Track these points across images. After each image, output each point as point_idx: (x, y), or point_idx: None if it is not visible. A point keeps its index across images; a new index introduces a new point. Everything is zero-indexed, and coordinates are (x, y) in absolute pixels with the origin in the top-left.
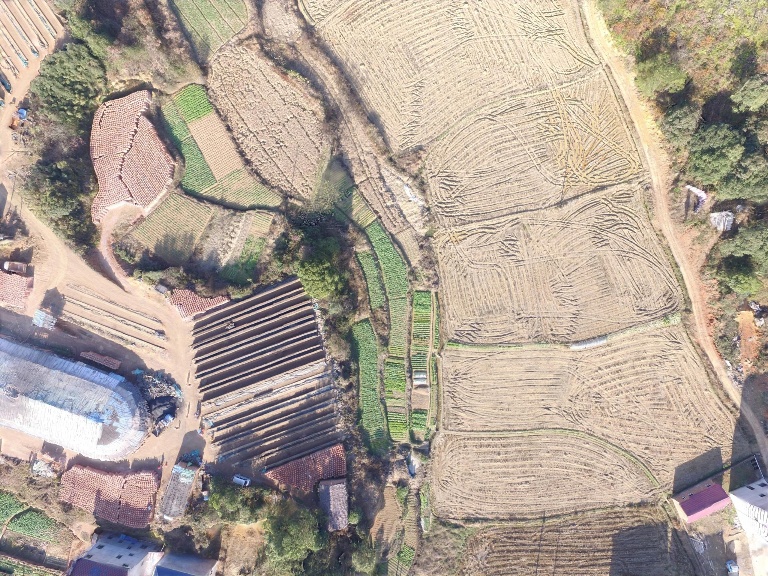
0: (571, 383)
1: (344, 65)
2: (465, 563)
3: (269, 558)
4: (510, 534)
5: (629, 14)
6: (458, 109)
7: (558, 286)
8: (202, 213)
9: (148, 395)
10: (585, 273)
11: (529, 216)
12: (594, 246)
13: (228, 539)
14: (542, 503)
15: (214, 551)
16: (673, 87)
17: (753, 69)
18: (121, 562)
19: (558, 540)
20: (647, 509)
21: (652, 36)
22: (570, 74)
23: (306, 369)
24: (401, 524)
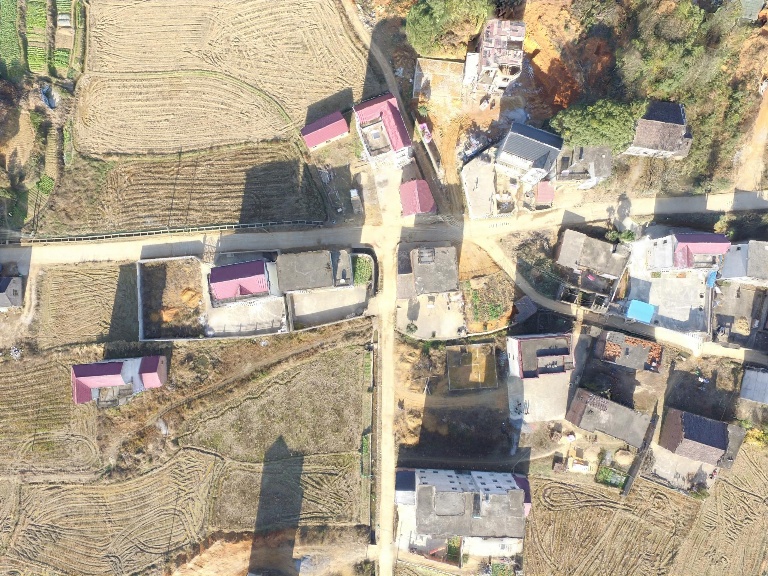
0: (212, 28)
1: None
2: (105, 196)
3: None
4: (148, 168)
5: None
6: None
7: None
8: None
9: None
10: None
11: None
12: None
13: None
14: (180, 139)
15: None
16: None
17: None
18: None
19: (194, 175)
20: (280, 145)
21: None
22: None
23: None
24: (36, 149)
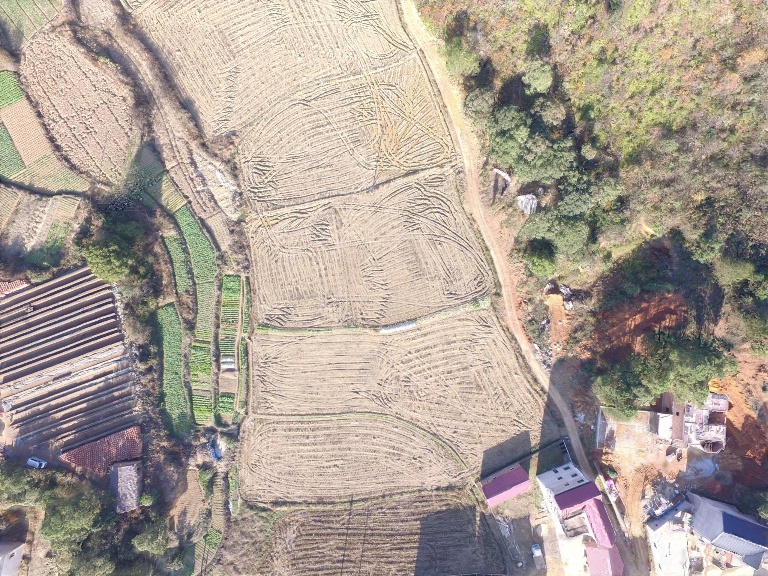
0: (380, 367)
1: (160, 51)
2: (273, 546)
3: None
4: (318, 517)
5: None
6: (272, 94)
7: (369, 270)
8: (9, 198)
9: None
10: (396, 257)
11: (341, 200)
12: (405, 230)
13: (35, 522)
14: (350, 487)
15: (20, 534)
16: (474, 70)
17: (547, 51)
18: None
19: (366, 524)
20: (455, 493)
21: (454, 19)
22: (384, 59)
23: (105, 352)
24: (204, 507)
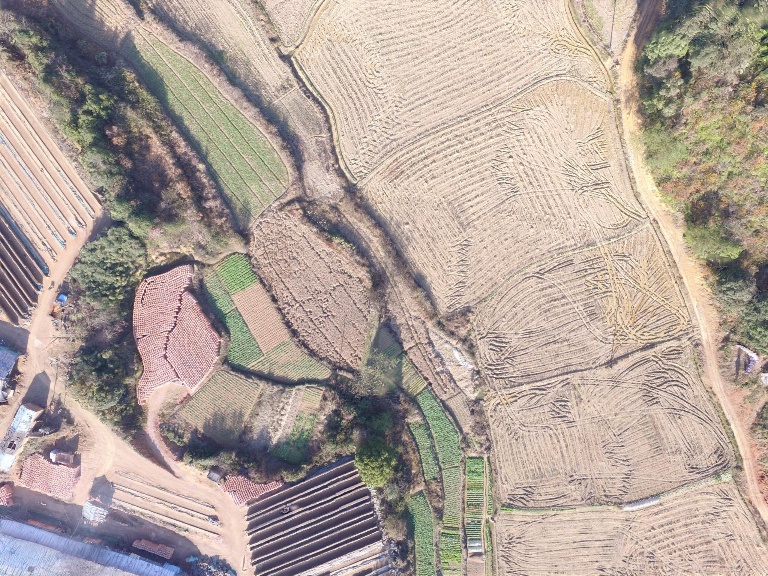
0: (625, 543)
1: (388, 224)
2: None
3: None
4: None
5: (679, 174)
6: (505, 268)
7: (610, 446)
8: (250, 390)
9: None
10: (636, 432)
11: (579, 376)
12: (645, 405)
13: None
14: None
15: None
16: (725, 252)
17: None
18: None
19: None
20: None
21: (703, 199)
22: (617, 229)
23: (363, 550)
24: None
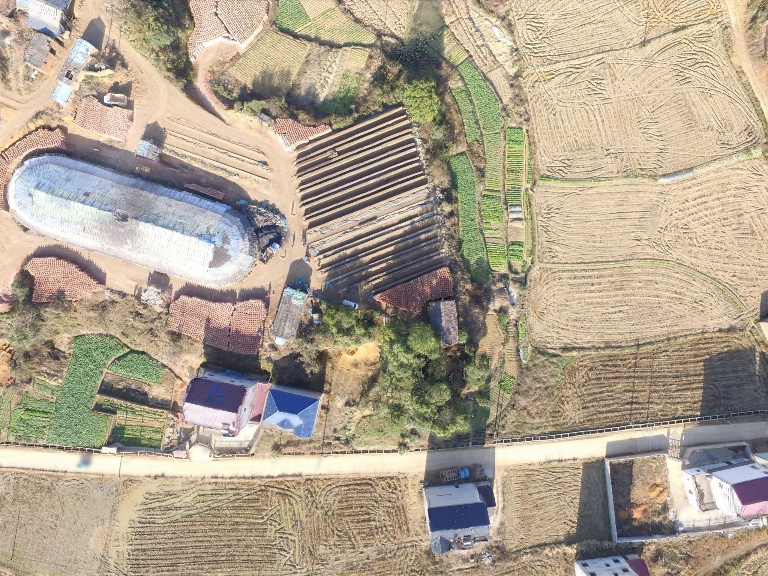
0: (660, 215)
1: None
2: (563, 391)
3: (382, 376)
4: (606, 362)
5: None
6: None
7: (644, 122)
8: (298, 50)
9: (254, 224)
10: (670, 109)
11: (614, 56)
12: (677, 83)
13: (332, 373)
14: (636, 331)
15: (319, 384)
16: None
17: None
18: (236, 383)
19: (652, 366)
20: (736, 334)
21: None
22: None
23: (409, 196)
24: (503, 351)
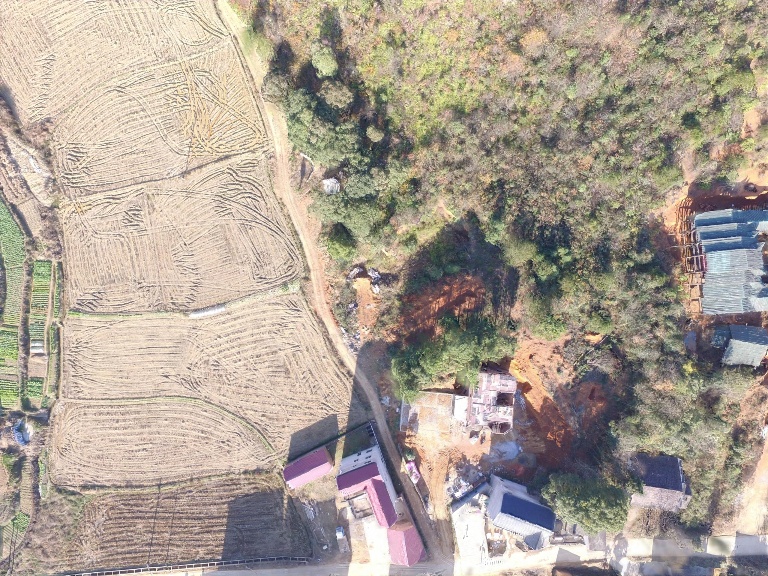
0: (190, 351)
1: None
2: (82, 530)
3: None
4: (127, 501)
5: None
6: (87, 81)
7: (180, 255)
8: None
9: None
10: (207, 242)
11: (154, 186)
12: (217, 215)
13: None
14: (159, 470)
15: None
16: None
17: (339, 35)
18: None
19: (175, 507)
20: (262, 476)
21: None
22: (199, 45)
23: None
24: (10, 490)
